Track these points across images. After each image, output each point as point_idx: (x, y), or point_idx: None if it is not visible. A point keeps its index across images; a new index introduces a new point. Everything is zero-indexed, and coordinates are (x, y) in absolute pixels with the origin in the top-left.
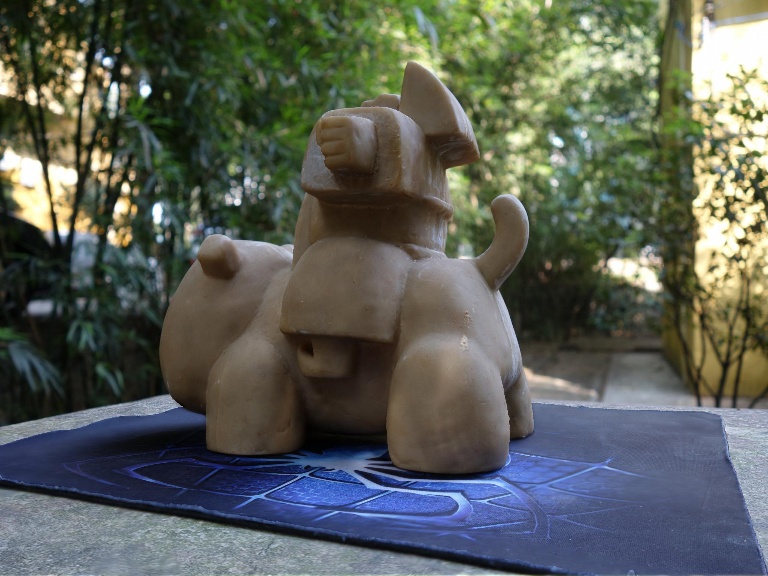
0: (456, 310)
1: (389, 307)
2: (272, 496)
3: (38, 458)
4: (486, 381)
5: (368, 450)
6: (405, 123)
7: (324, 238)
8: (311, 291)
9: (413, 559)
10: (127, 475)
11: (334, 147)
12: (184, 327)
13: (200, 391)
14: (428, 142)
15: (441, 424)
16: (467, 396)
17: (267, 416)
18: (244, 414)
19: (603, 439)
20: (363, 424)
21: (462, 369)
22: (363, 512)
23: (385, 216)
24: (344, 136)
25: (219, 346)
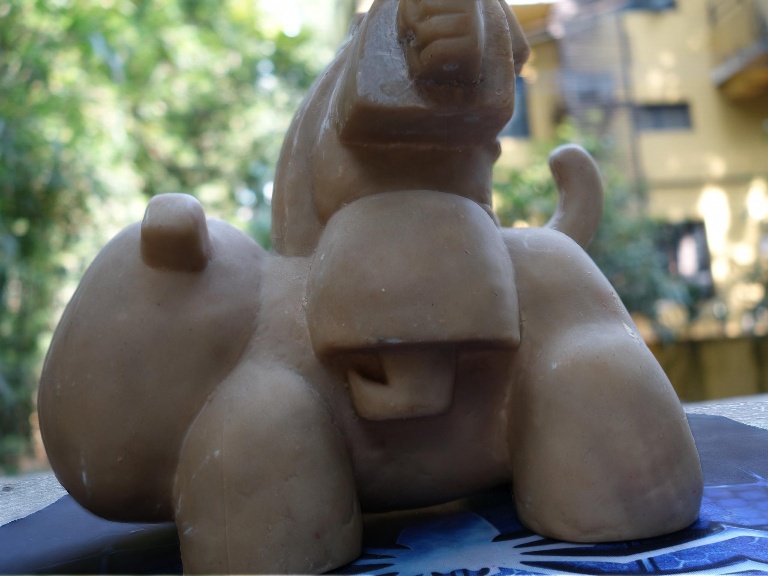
0: (601, 289)
1: (513, 291)
2: None
3: None
4: None
5: (461, 526)
6: None
7: (366, 196)
8: (397, 271)
9: None
10: None
11: (453, 23)
12: (121, 363)
13: (161, 479)
14: None
15: (649, 458)
16: (670, 409)
17: (326, 500)
18: (286, 504)
19: None
20: (448, 486)
21: (651, 370)
22: None
23: (457, 161)
24: (467, 7)
25: (198, 390)
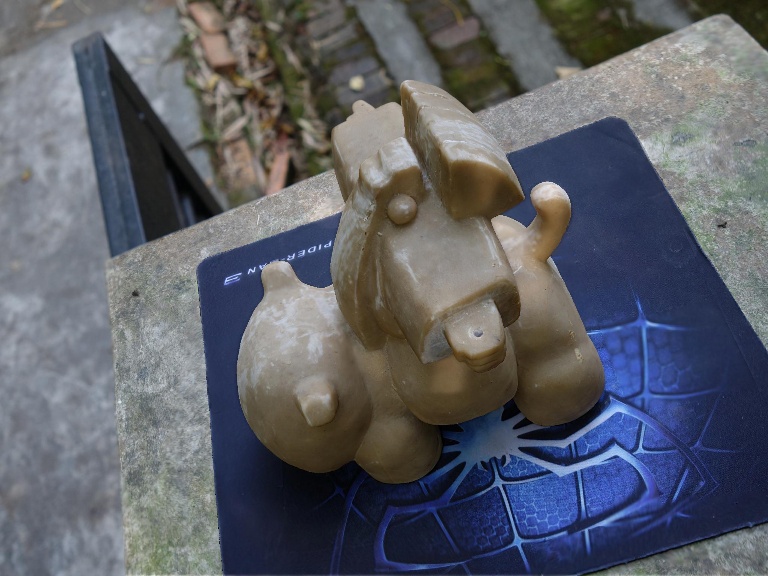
0: (564, 337)
1: None
2: (525, 535)
3: None
4: None
5: None
6: None
7: None
8: (456, 405)
9: (675, 556)
10: (397, 571)
11: None
12: (317, 454)
13: None
14: None
15: None
16: None
17: (429, 455)
18: (414, 466)
19: (600, 253)
20: None
21: (586, 375)
22: (600, 521)
23: None
24: (498, 357)
25: (357, 443)
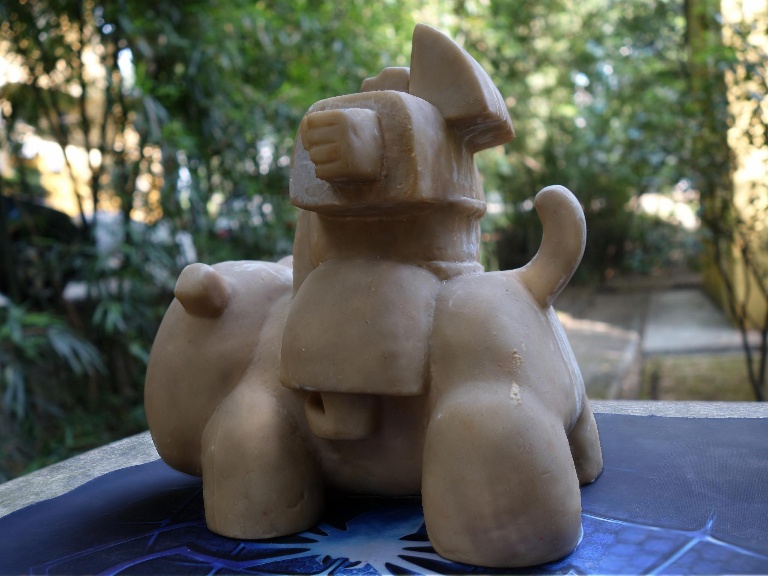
0: (501, 349)
1: (414, 350)
2: None
3: (3, 558)
4: (547, 443)
5: (402, 519)
6: (417, 109)
7: (327, 261)
8: (314, 336)
9: None
10: None
11: (325, 153)
12: (167, 380)
13: (194, 455)
14: (449, 127)
15: (492, 506)
16: (524, 467)
17: (274, 490)
18: (245, 489)
19: (693, 479)
20: (393, 487)
21: (515, 431)
22: None
23: (401, 229)
24: (337, 137)
25: (211, 402)
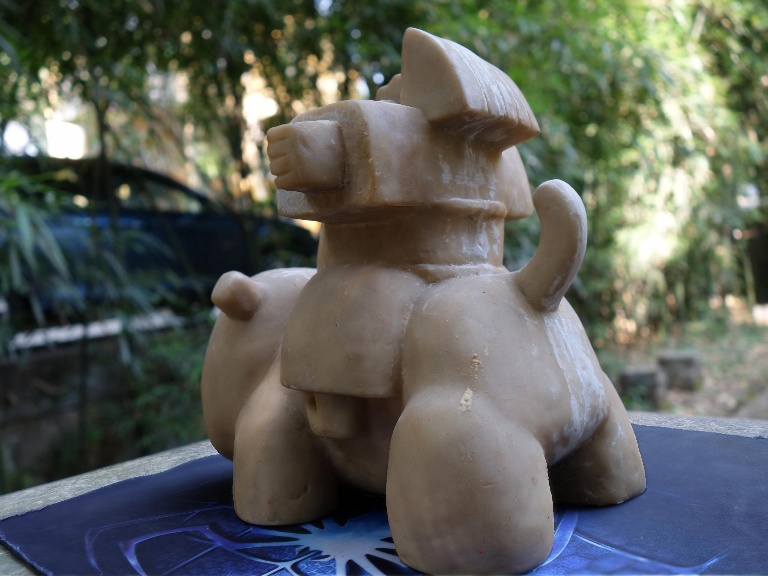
0: (460, 354)
1: (382, 353)
2: None
3: (80, 519)
4: (495, 453)
5: None
6: (380, 115)
7: None
8: (296, 338)
9: None
10: (122, 552)
11: (279, 165)
12: (210, 376)
13: (231, 445)
14: (436, 129)
15: (432, 513)
16: (463, 476)
17: (277, 481)
18: (254, 478)
19: (738, 511)
20: None
21: (458, 438)
22: None
23: (386, 233)
24: (287, 150)
25: (240, 397)
